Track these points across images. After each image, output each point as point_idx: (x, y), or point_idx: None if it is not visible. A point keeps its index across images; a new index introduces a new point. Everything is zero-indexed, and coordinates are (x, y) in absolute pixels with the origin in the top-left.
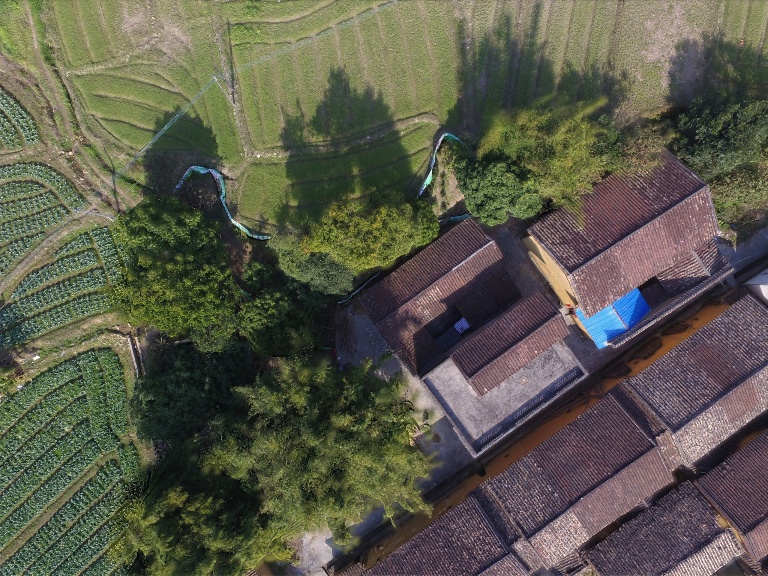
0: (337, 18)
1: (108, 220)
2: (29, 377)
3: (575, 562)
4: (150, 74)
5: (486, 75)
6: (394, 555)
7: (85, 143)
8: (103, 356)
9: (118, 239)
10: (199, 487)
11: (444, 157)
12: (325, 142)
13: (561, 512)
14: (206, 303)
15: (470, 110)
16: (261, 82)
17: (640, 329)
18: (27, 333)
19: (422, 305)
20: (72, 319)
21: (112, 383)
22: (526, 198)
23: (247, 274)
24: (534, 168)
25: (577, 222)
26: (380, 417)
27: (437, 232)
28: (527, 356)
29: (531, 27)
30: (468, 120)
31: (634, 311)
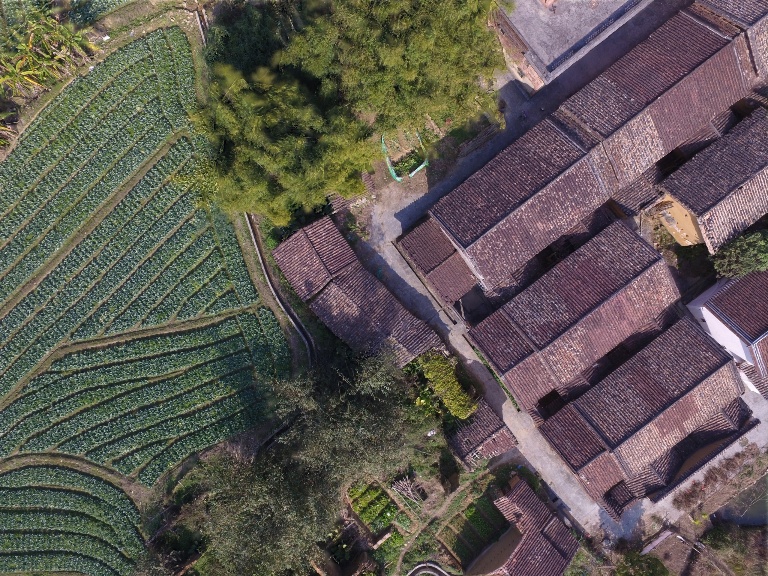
0: None
1: None
2: (100, 58)
3: (649, 196)
4: None
5: None
6: (470, 180)
7: None
8: (171, 33)
9: None
10: None
11: None
12: None
13: (639, 111)
14: None
15: None
16: None
17: None
18: (98, 8)
19: None
20: None
21: (181, 59)
22: None
23: None
24: None
25: None
26: None
27: None
28: None
29: None
30: None
31: None
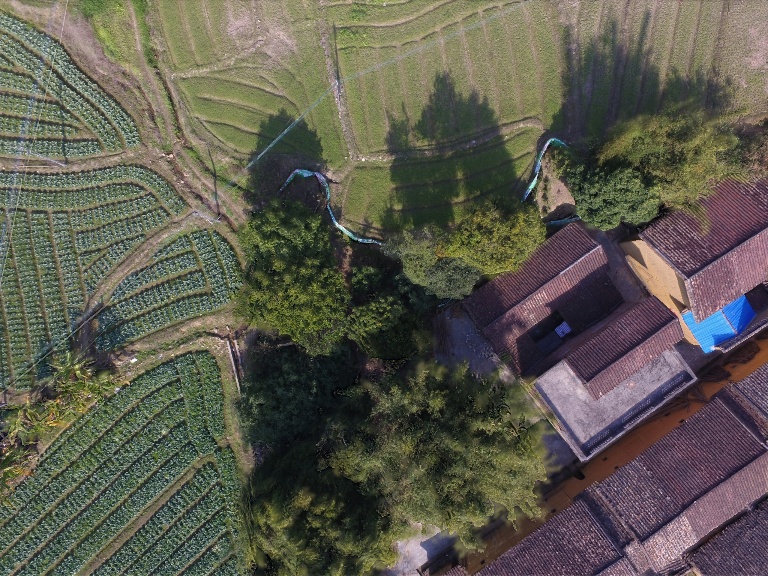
0: (443, 22)
1: (208, 223)
2: (126, 380)
3: (678, 565)
4: (255, 77)
5: (591, 80)
6: (503, 558)
7: (186, 146)
8: (201, 359)
9: (218, 242)
10: (319, 491)
11: (554, 162)
12: (430, 146)
13: (675, 515)
14: (323, 307)
15: (575, 115)
16: (367, 86)
17: (750, 334)
18: (126, 336)
19: (528, 309)
20: (171, 322)
21: (210, 386)
22: (650, 204)
23: (356, 278)
24: (662, 174)
25: (690, 227)
26: (478, 420)
27: (544, 236)
28: (642, 360)
29: (637, 33)
30: (573, 125)
31: (741, 316)
